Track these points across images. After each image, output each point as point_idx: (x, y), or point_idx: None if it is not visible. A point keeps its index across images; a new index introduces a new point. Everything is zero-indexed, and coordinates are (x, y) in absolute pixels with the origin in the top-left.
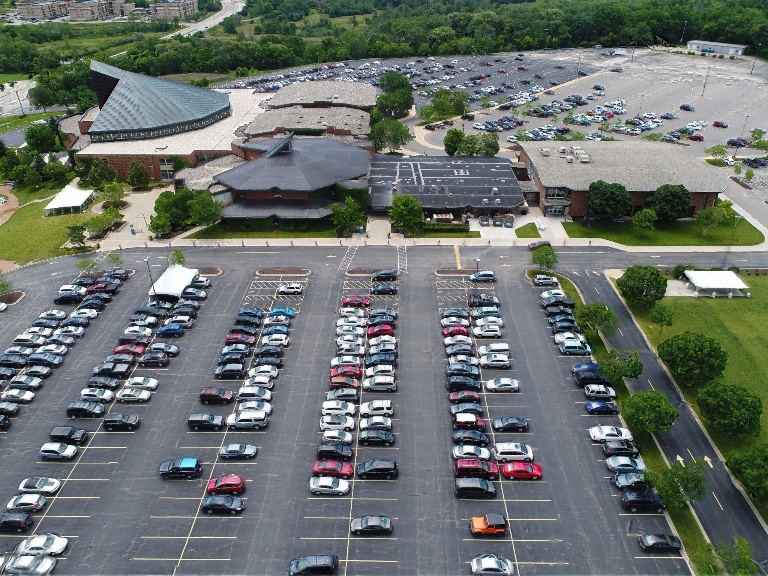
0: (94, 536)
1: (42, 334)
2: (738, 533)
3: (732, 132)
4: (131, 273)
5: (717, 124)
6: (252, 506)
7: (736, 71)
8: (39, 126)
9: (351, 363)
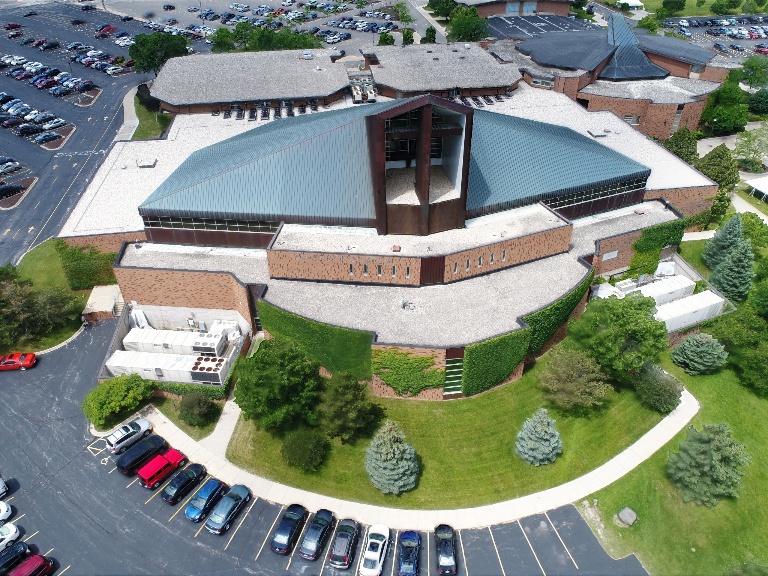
0: None
1: None
2: None
3: None
4: None
5: None
6: None
7: None
8: (621, 300)
9: None
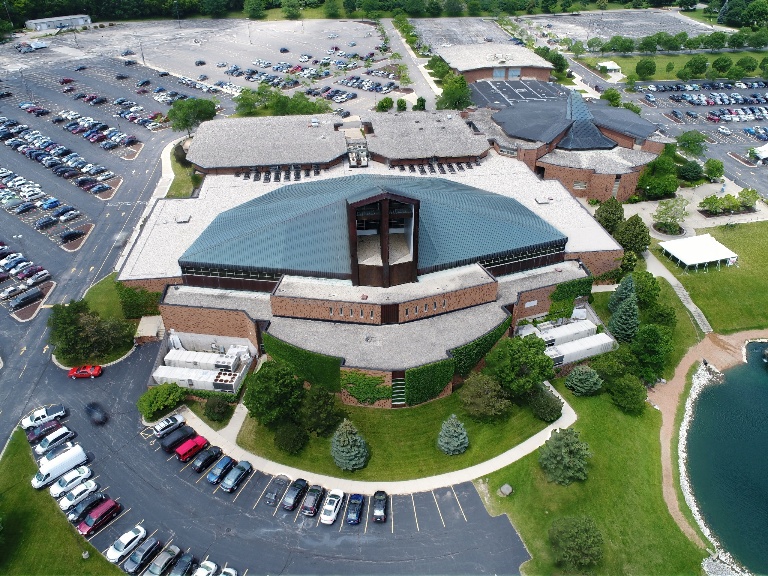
0: None
1: None
2: (760, 79)
3: (352, 49)
4: None
5: (336, 49)
6: None
7: (172, 30)
8: (520, 340)
9: None
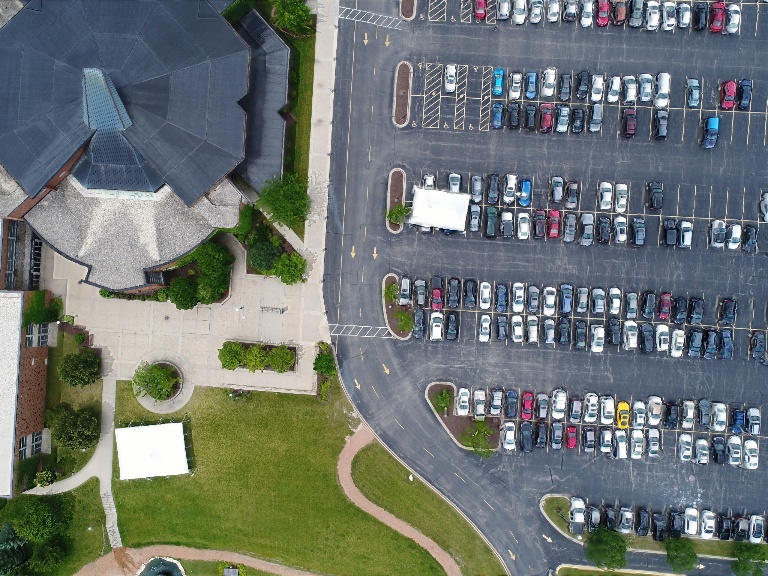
0: (761, 178)
1: (522, 322)
2: None
3: None
4: (394, 277)
5: None
6: (743, 74)
7: None
8: None
9: (593, 5)
